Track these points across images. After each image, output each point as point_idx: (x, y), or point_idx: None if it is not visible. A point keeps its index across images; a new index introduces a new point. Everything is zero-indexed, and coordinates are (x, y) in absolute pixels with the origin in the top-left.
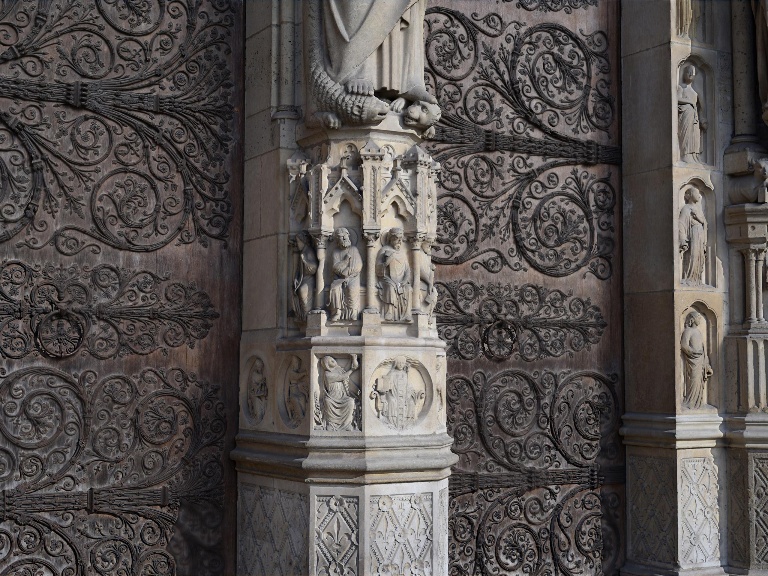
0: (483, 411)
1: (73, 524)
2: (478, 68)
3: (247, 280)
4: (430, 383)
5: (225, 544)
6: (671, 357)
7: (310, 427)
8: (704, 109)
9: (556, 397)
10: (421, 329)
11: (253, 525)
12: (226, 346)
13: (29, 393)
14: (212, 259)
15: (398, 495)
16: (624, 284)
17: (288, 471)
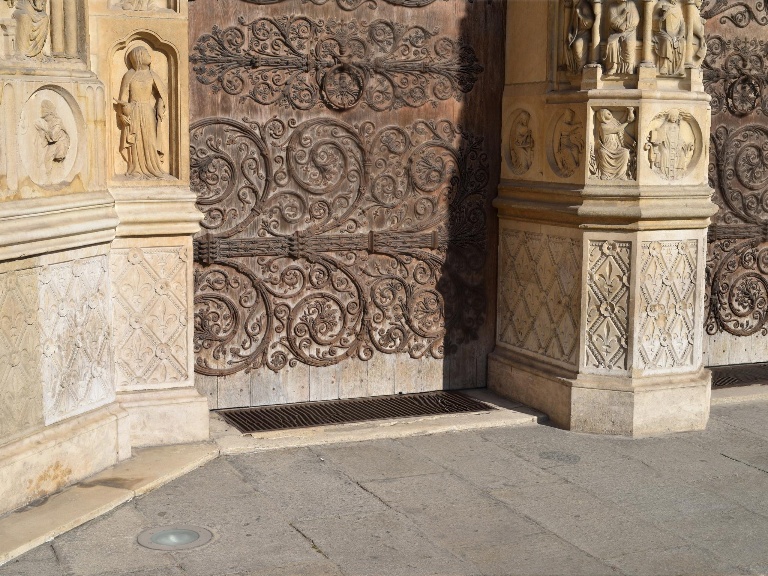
0: (724, 165)
1: (356, 263)
2: None
3: (511, 35)
4: (700, 136)
5: (487, 285)
6: None
7: (585, 176)
8: None
9: None
10: (693, 83)
11: (516, 268)
12: (489, 99)
13: (316, 142)
14: (477, 14)
15: (667, 241)
16: None
17: (559, 218)
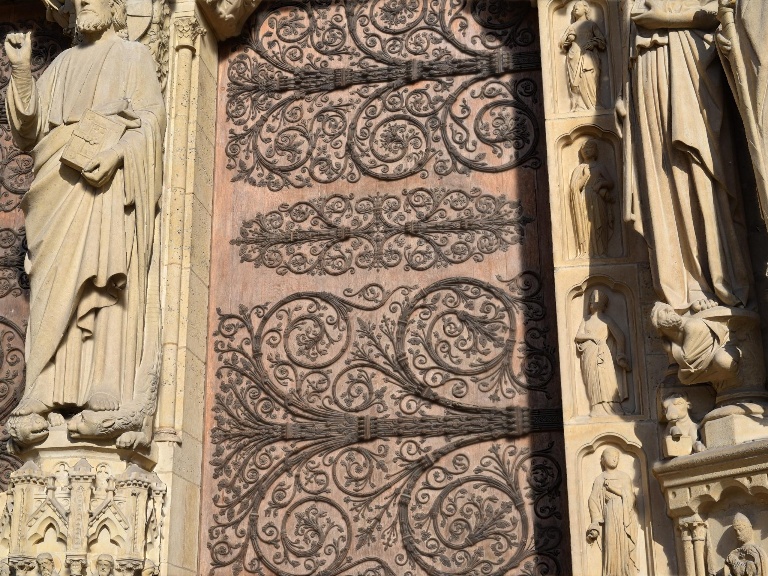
0: None
1: None
2: (352, 348)
3: None
4: None
5: None
6: None
7: None
8: (627, 341)
9: None
10: None
11: None
12: None
13: None
14: None
15: None
16: None
17: None
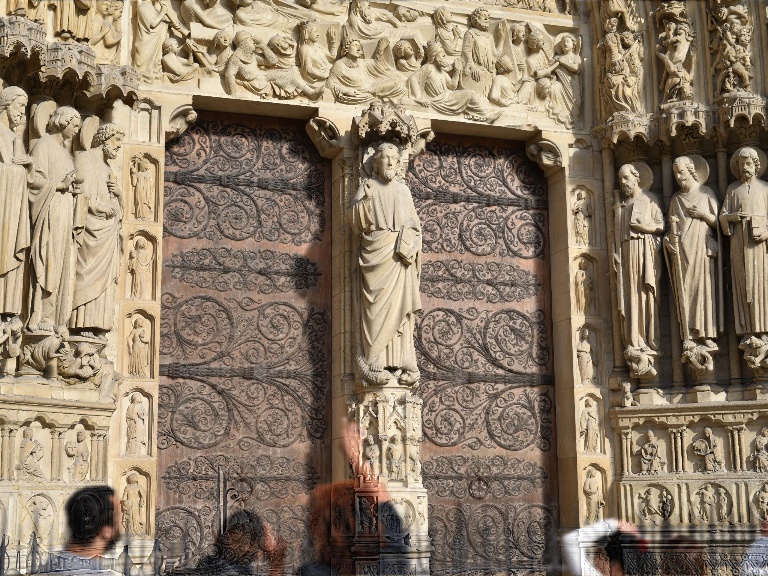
0: (470, 527)
1: None
2: (463, 338)
3: (334, 459)
4: (414, 510)
5: None
6: (577, 495)
7: (356, 532)
8: (596, 353)
9: (515, 519)
10: (409, 483)
11: None
12: (325, 493)
13: None
14: (317, 449)
15: (398, 565)
16: (558, 453)
17: (348, 554)
